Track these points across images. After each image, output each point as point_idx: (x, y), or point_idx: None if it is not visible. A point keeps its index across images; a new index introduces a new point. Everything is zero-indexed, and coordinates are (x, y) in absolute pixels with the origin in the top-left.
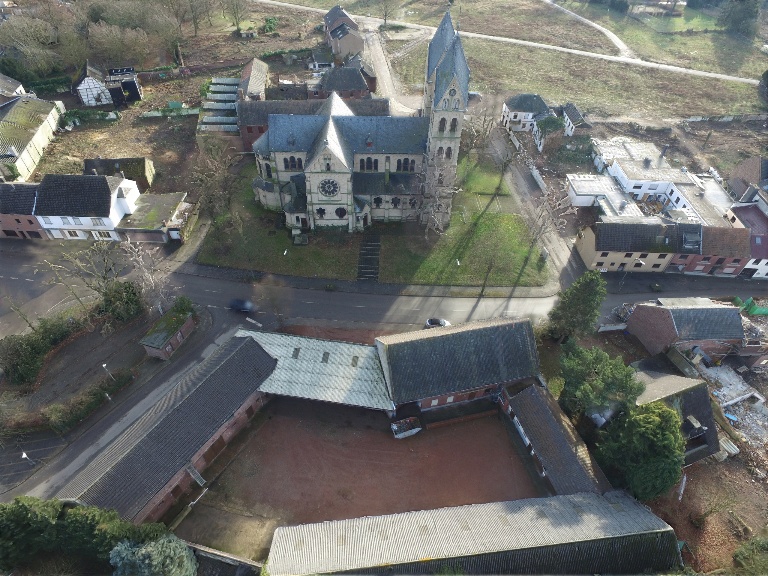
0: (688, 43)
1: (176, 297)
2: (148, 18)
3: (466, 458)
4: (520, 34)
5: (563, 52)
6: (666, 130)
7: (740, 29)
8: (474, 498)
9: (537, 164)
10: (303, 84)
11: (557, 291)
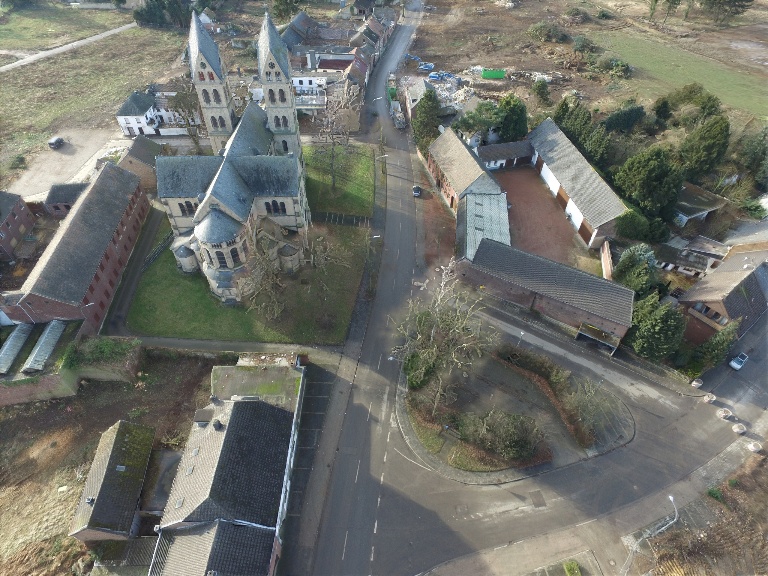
0: (26, 26)
1: None
2: None
3: (512, 187)
4: None
5: None
6: None
7: (31, 0)
8: (534, 186)
9: None
10: None
11: (378, 145)
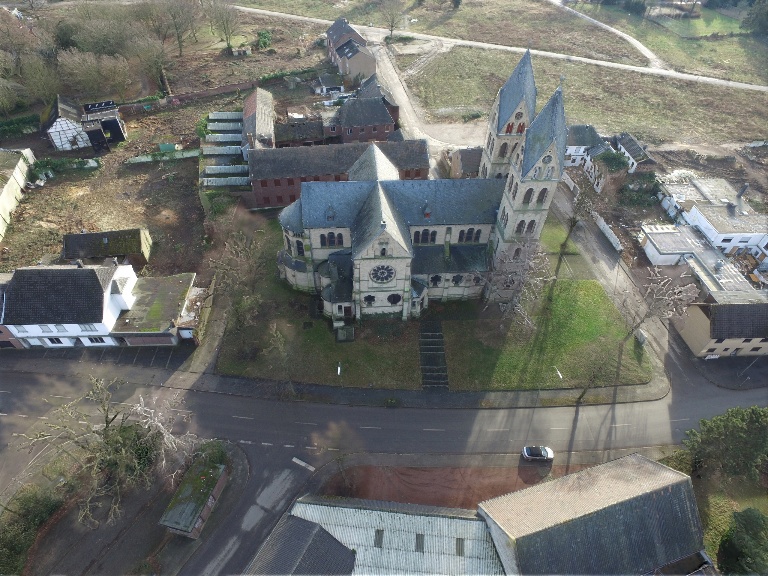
0: (717, 49)
1: (205, 455)
2: (127, 41)
3: None
4: (539, 43)
5: (590, 64)
6: (729, 159)
7: None
8: None
9: (598, 209)
10: (316, 117)
11: (667, 390)
